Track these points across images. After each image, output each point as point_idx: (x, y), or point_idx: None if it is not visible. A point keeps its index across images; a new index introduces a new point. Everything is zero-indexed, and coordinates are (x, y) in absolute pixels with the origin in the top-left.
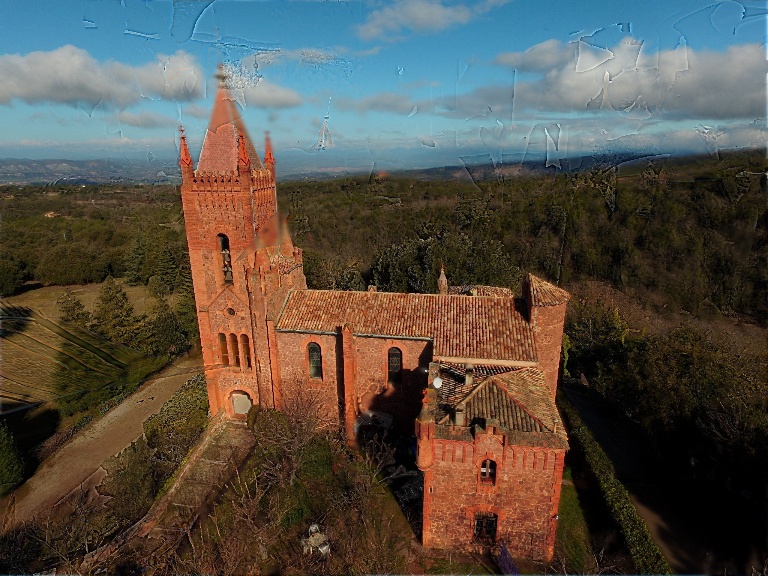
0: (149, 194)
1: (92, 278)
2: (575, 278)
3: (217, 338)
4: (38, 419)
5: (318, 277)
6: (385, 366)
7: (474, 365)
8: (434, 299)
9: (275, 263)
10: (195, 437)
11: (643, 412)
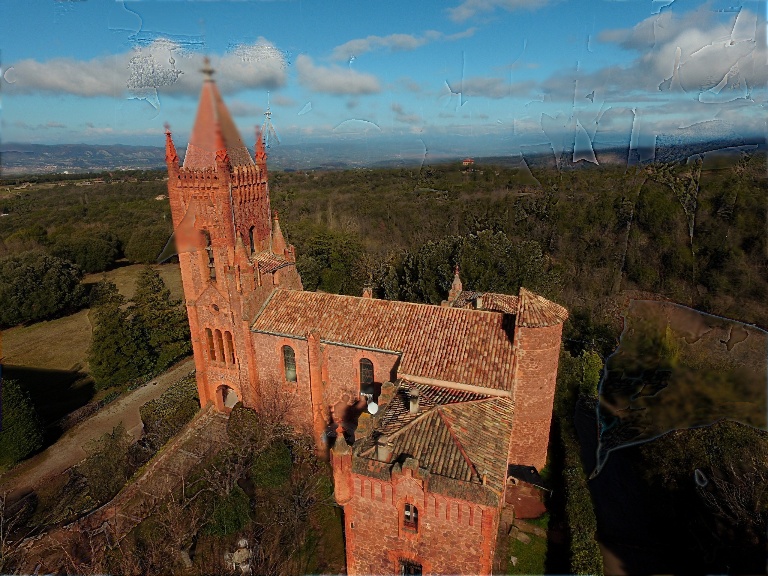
0: None
1: (170, 259)
2: (639, 285)
3: (204, 332)
4: (80, 389)
5: (358, 270)
6: (356, 377)
7: (438, 388)
8: (415, 309)
9: (254, 262)
10: (178, 427)
11: (646, 462)
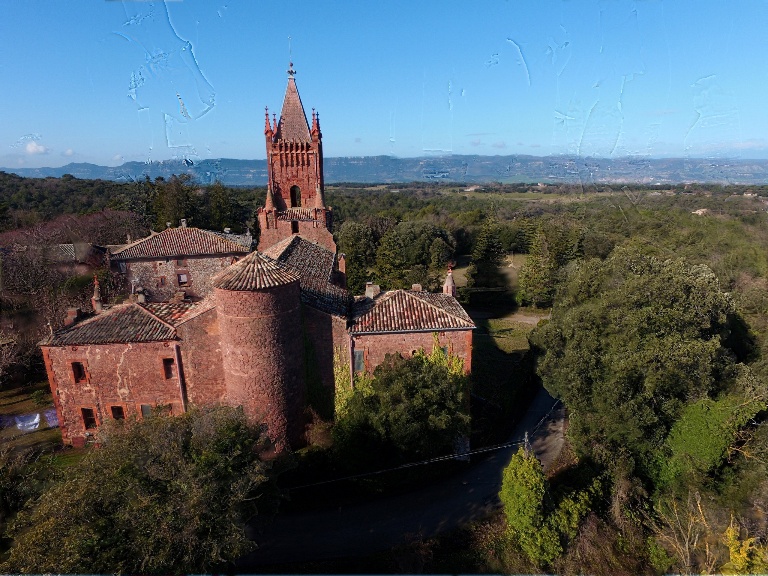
0: (586, 181)
1: None
2: None
3: None
4: None
5: None
6: None
7: None
8: None
9: None
10: None
11: None
